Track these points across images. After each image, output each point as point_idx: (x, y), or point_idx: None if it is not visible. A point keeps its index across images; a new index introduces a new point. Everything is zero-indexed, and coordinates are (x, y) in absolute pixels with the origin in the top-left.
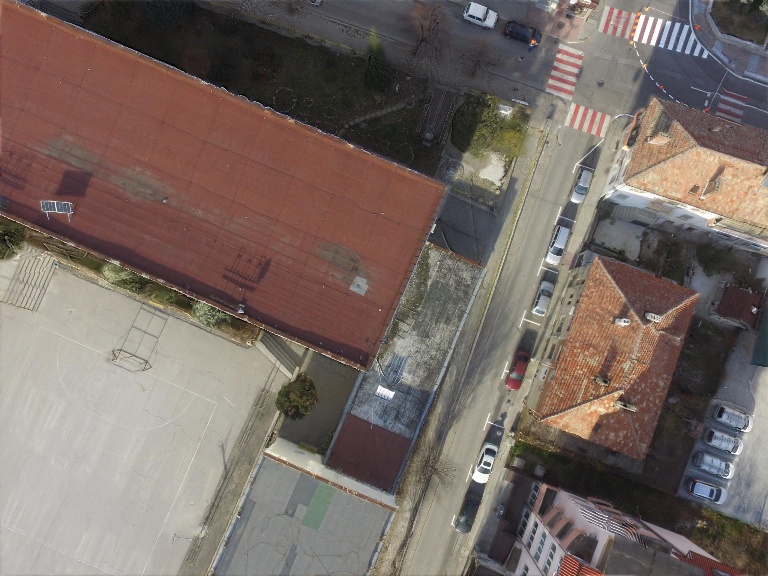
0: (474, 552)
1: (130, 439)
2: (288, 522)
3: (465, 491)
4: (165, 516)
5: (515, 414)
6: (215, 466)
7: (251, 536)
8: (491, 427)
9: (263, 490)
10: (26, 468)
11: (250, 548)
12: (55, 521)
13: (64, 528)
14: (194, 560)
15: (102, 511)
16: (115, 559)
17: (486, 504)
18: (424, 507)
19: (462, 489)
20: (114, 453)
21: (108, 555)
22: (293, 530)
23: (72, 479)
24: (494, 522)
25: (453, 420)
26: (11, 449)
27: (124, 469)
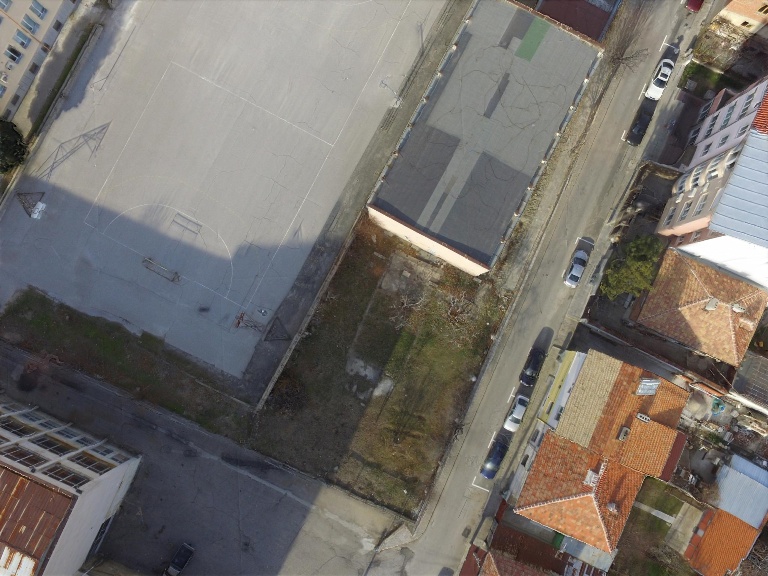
0: (643, 163)
1: (334, 13)
2: (502, 52)
3: (637, 108)
4: (363, 86)
5: (691, 37)
6: (413, 44)
7: (466, 64)
8: (667, 49)
9: (479, 24)
10: (236, 31)
11: (464, 75)
12: (260, 81)
13: (268, 89)
14: (388, 128)
15: (304, 76)
16: (314, 121)
17: (656, 121)
18: (597, 119)
19: (634, 106)
20: (319, 24)
21: (307, 117)
22: (507, 59)
23: (278, 44)
24: (663, 138)
25: (631, 39)
26: (223, 13)
27: (327, 39)
